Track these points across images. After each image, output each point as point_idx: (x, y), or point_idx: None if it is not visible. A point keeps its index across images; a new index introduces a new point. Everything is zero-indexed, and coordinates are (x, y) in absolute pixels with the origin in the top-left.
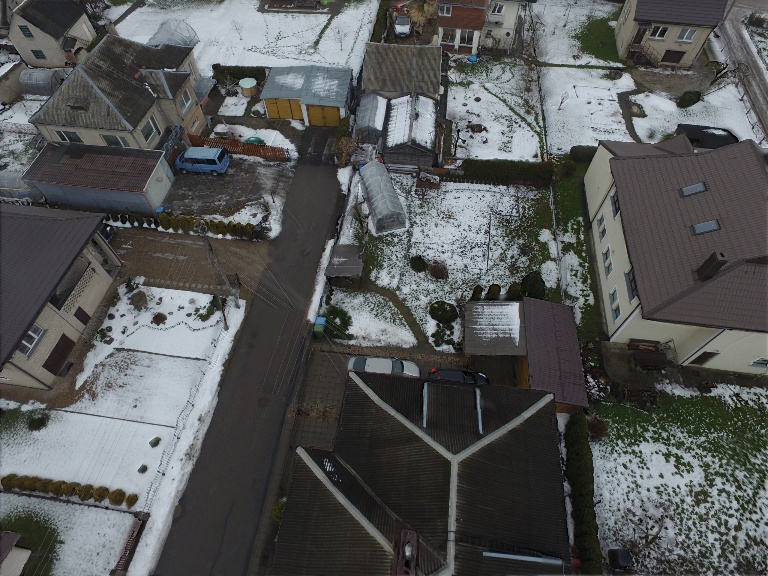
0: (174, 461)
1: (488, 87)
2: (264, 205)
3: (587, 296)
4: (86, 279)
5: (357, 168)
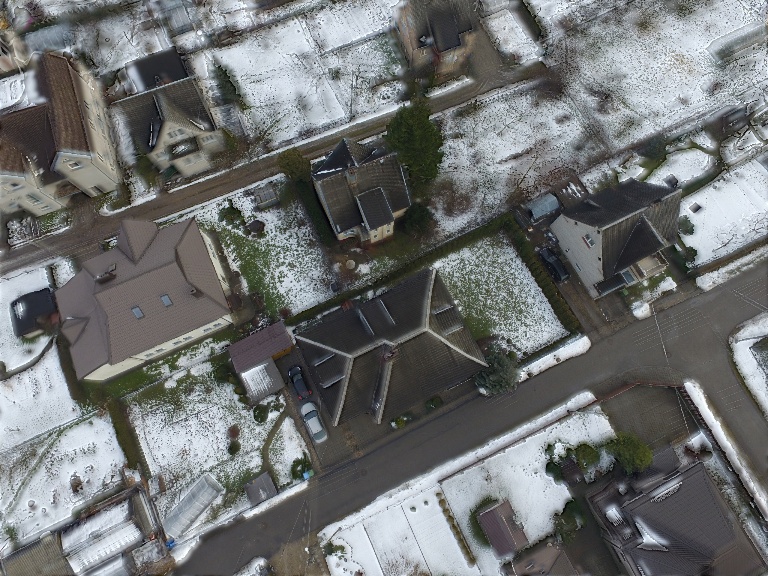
0: (414, 492)
1: (6, 505)
2: None
3: (207, 343)
4: None
5: (169, 547)
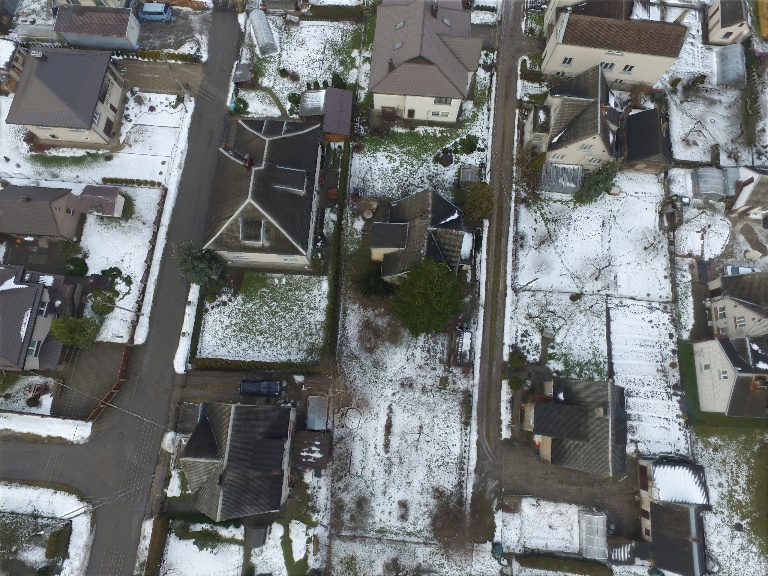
0: (174, 169)
1: None
2: (196, 41)
3: None
4: (110, 89)
5: (249, 13)
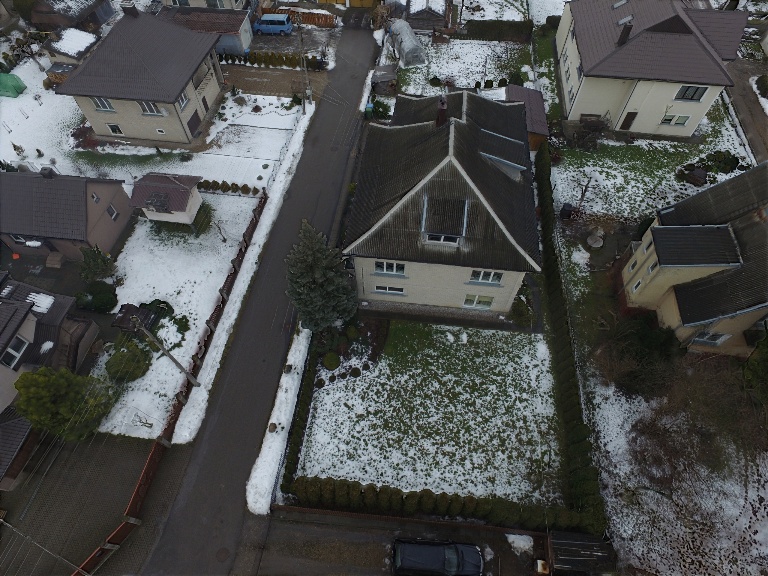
0: (280, 174)
1: None
2: (321, 52)
3: (554, 99)
4: (208, 79)
5: (388, 30)
